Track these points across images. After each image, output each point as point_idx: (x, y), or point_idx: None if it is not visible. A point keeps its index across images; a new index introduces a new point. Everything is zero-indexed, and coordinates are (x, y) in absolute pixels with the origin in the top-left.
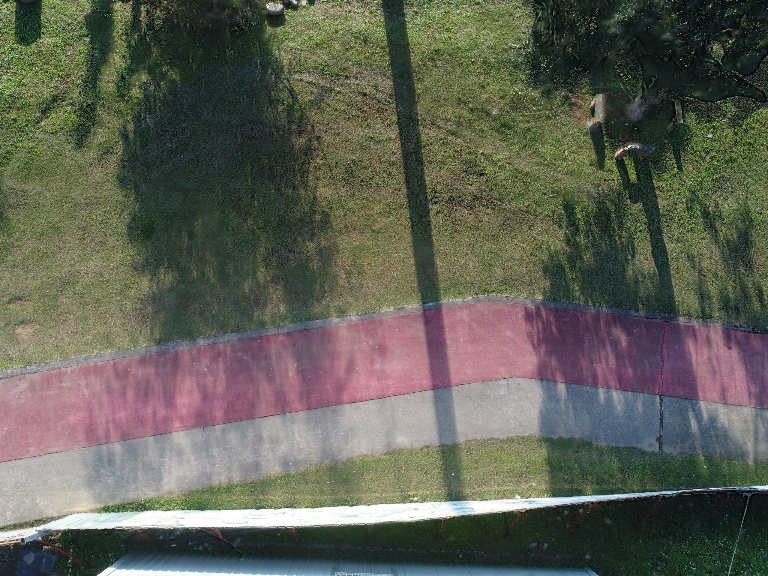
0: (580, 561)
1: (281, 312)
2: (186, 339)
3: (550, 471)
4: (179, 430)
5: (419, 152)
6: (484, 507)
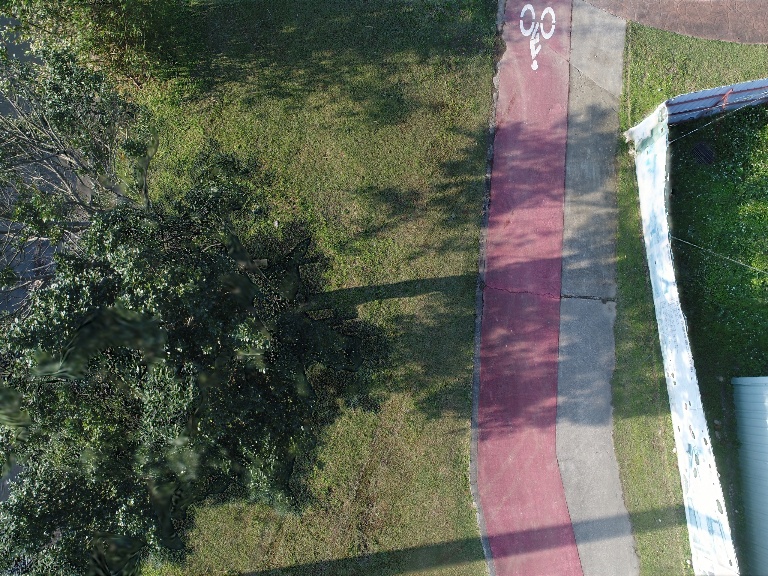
0: (726, 387)
1: None
2: None
3: (645, 415)
4: None
5: (304, 569)
6: (708, 507)
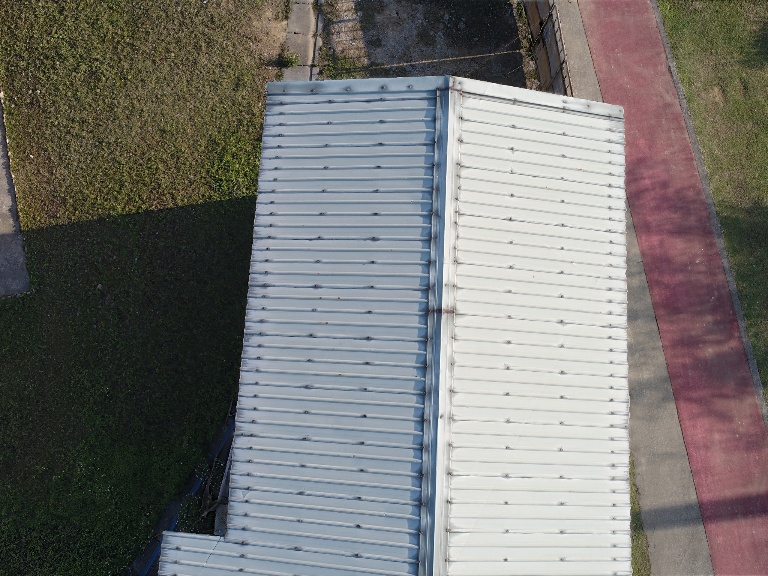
0: None
1: (762, 334)
2: (725, 241)
3: None
4: (638, 239)
5: None
6: None
